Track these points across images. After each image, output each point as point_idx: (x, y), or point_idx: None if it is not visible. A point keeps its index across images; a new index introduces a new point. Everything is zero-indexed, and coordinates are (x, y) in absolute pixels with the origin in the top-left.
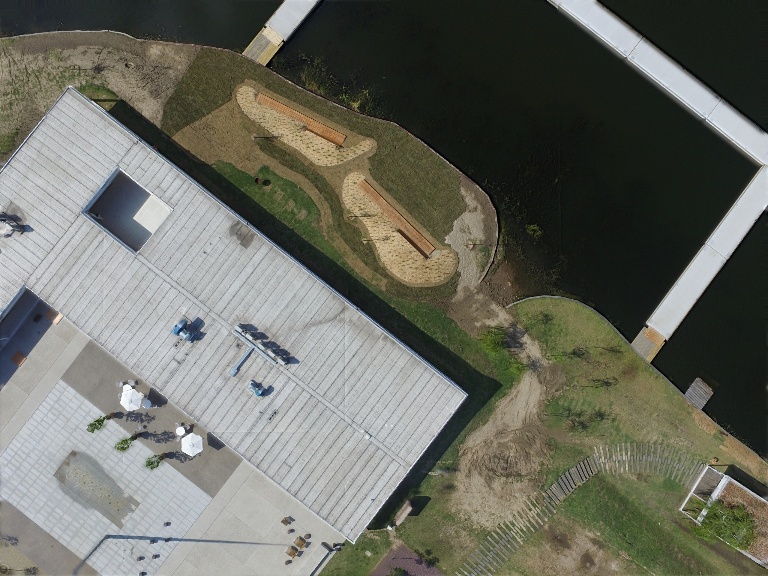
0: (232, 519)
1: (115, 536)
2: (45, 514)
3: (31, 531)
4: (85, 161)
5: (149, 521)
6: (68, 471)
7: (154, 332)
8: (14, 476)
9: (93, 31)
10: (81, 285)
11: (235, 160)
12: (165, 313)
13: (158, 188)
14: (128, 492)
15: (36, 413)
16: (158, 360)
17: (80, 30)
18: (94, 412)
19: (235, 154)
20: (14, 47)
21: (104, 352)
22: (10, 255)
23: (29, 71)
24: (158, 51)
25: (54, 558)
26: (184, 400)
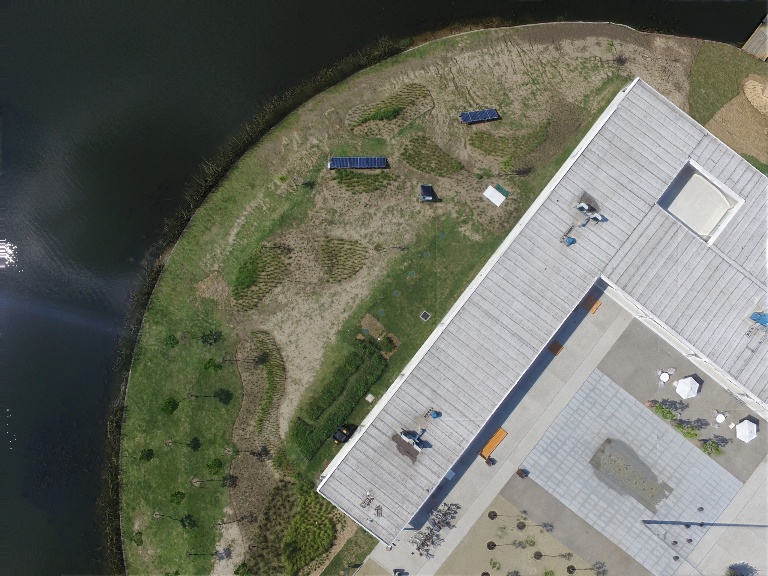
0: (762, 503)
1: (649, 521)
2: (580, 501)
3: (567, 517)
4: (657, 152)
5: (682, 506)
6: (603, 458)
7: (727, 321)
8: (550, 463)
9: (596, 23)
10: (657, 275)
11: (756, 153)
12: (738, 302)
13: (729, 180)
14: (662, 478)
15: (572, 401)
16: (732, 348)
17: (582, 21)
18: (629, 400)
19: (754, 147)
20: (520, 37)
21: (639, 341)
22: (585, 244)
23: (544, 61)
24: (662, 44)
25: (589, 544)
26: (758, 387)
